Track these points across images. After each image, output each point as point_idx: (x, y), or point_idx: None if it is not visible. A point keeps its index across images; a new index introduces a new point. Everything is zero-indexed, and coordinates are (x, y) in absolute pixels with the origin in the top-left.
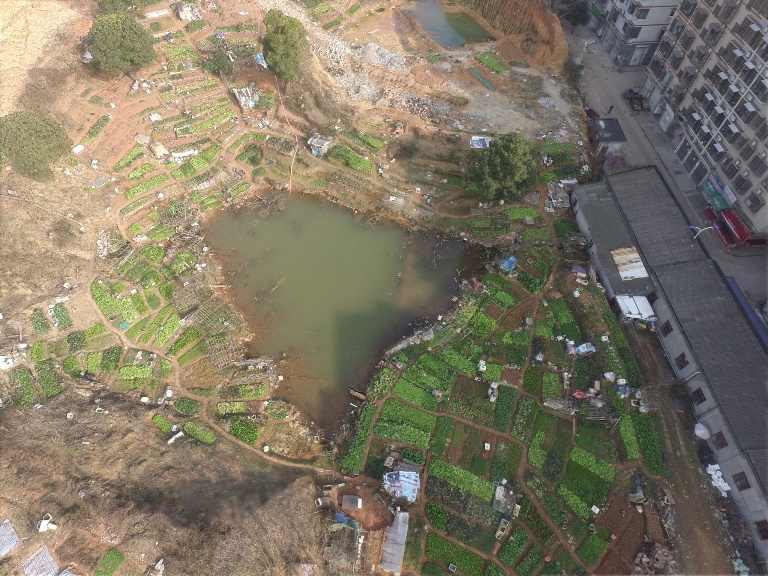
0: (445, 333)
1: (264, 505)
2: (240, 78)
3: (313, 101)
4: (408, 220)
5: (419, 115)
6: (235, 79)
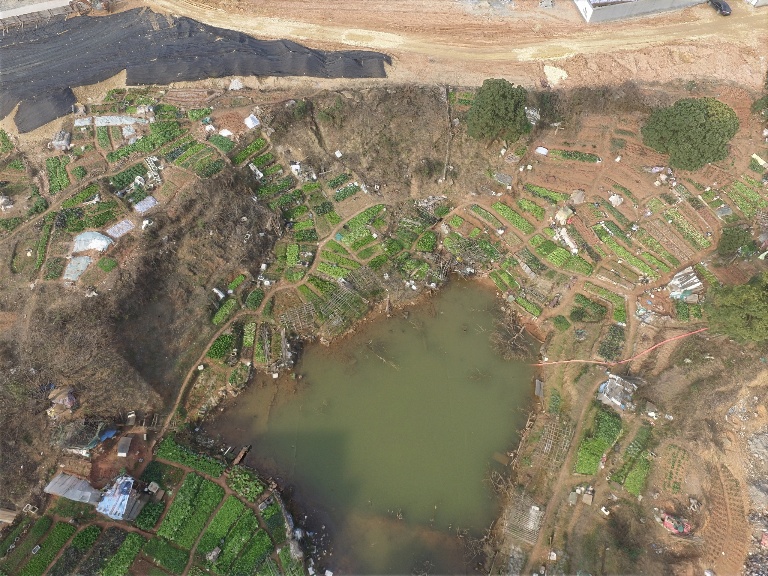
0: (283, 573)
1: (130, 365)
2: (725, 272)
3: (705, 375)
4: (503, 537)
5: (747, 574)
6: (721, 267)
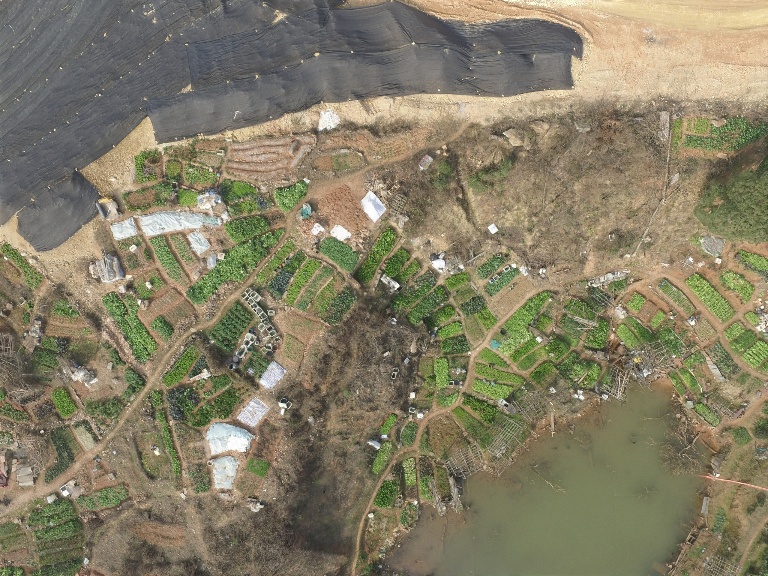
0: None
1: (315, 552)
2: None
3: None
4: None
5: None
6: None
